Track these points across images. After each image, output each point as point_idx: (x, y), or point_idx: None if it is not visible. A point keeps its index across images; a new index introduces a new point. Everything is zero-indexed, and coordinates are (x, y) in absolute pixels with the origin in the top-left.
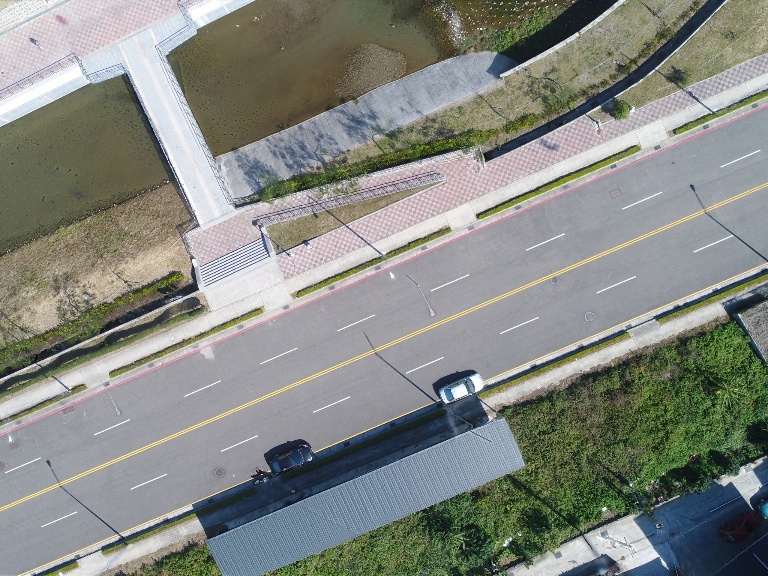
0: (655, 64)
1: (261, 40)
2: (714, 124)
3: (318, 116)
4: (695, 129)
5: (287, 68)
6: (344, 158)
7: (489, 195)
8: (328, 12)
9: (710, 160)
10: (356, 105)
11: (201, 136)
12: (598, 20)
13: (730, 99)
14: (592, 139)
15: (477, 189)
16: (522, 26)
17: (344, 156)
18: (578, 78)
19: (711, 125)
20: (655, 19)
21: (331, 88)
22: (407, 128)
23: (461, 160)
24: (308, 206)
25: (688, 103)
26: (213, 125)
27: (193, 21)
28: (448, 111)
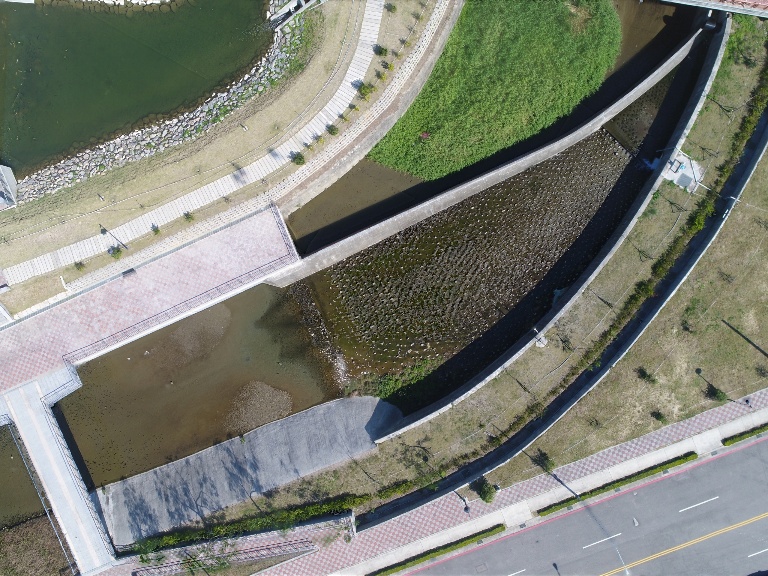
0: (525, 436)
1: (151, 373)
2: (578, 506)
3: (205, 451)
4: (559, 510)
5: (176, 402)
6: (222, 514)
7: (359, 565)
8: (217, 349)
9: (573, 541)
10: (241, 444)
11: (84, 488)
12: (471, 392)
13: (593, 483)
14: (459, 516)
15: (347, 558)
16: (404, 373)
17: (222, 512)
18: (450, 448)
19: (575, 507)
20: (526, 394)
21: (219, 423)
22: (284, 489)
23: (333, 530)
24: (185, 562)
25: (553, 485)
26: (103, 454)
27: (82, 362)
28: (324, 474)
